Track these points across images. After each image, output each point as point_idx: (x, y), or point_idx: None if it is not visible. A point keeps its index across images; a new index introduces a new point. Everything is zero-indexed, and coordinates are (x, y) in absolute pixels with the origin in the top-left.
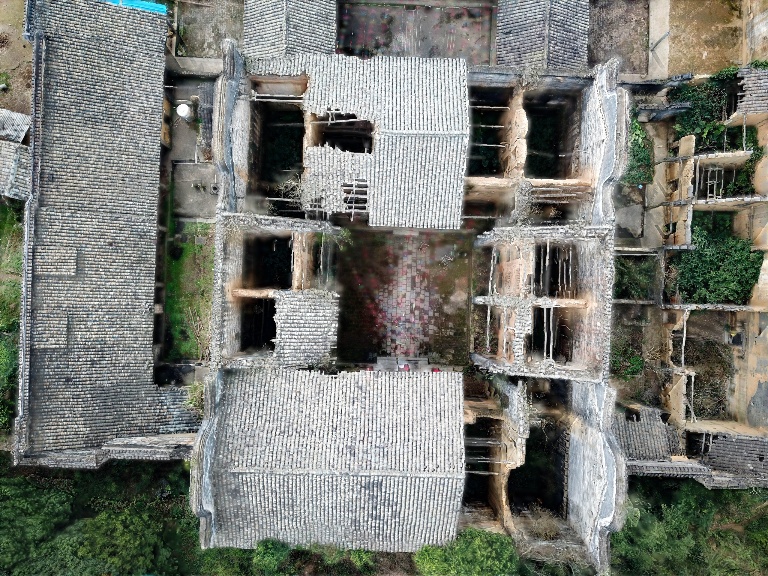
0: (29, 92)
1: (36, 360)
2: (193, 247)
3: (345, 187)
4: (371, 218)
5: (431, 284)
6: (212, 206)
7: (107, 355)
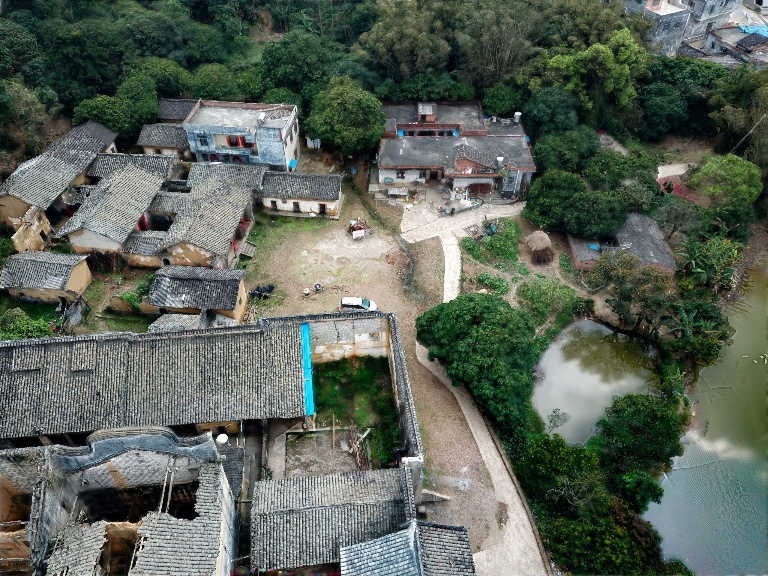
0: None
1: (5, 352)
2: None
3: (66, 571)
4: None
5: None
6: None
7: (2, 402)
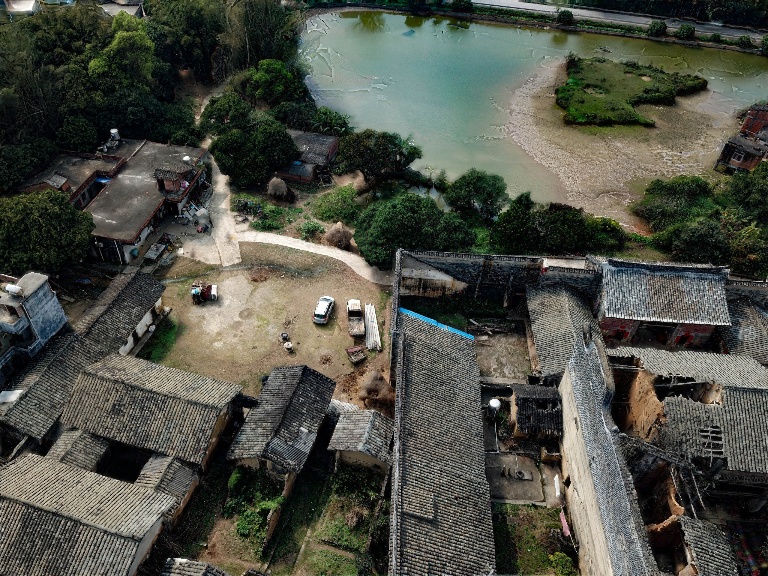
0: (344, 395)
1: None
2: (506, 527)
3: (701, 433)
4: (730, 463)
5: (760, 575)
6: (518, 490)
7: None
